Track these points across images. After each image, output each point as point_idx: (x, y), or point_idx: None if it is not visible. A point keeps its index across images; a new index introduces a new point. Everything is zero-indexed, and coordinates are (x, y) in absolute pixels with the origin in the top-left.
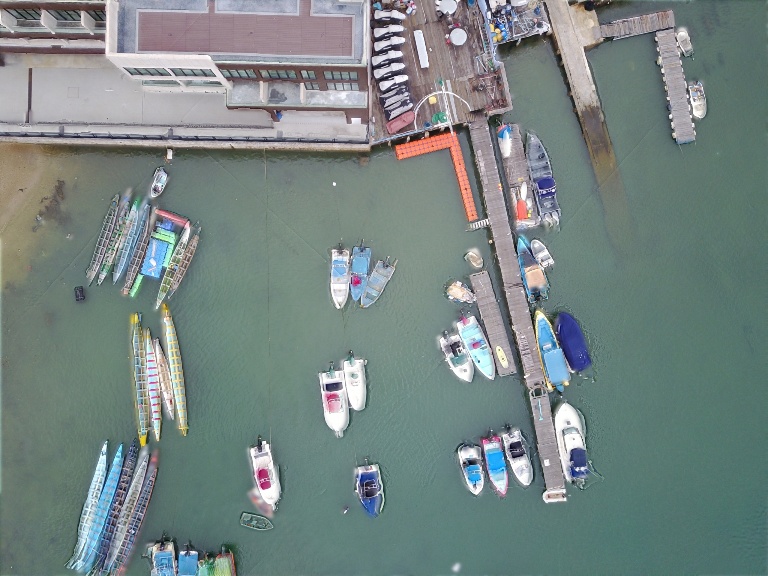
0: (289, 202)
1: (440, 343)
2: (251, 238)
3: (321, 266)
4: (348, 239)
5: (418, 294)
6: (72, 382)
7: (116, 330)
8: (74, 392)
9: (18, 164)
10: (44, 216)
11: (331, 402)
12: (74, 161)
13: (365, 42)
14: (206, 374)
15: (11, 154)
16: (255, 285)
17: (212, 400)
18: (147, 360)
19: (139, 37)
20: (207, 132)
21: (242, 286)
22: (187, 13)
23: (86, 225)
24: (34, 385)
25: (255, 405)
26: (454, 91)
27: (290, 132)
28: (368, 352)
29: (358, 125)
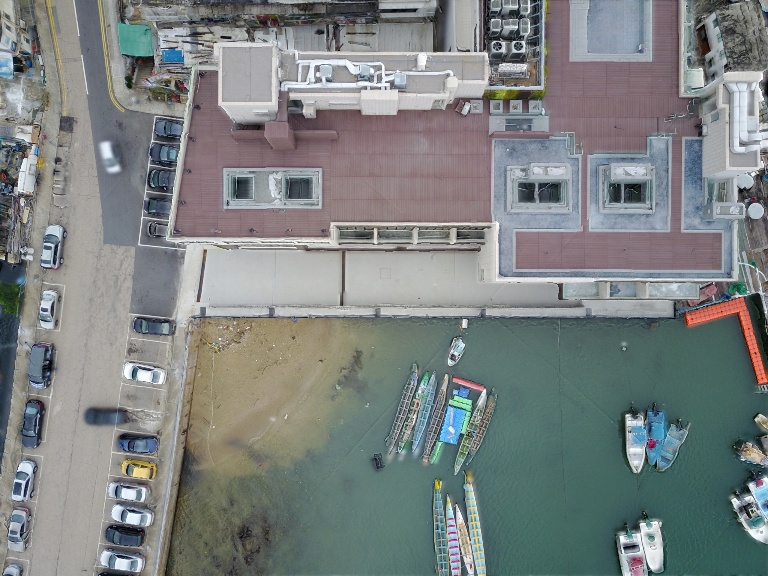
0: (579, 367)
1: (732, 504)
2: (543, 403)
3: (607, 426)
4: (639, 403)
5: (708, 455)
6: (371, 547)
7: (415, 496)
8: (373, 557)
9: (318, 336)
10: (343, 385)
11: (636, 569)
12: (371, 331)
13: (736, 258)
14: (502, 537)
15: (311, 326)
16: (549, 449)
17: (508, 562)
18: (447, 526)
19: (517, 256)
20: (519, 311)
21: (535, 450)
22: (562, 232)
23: (382, 393)
24: (334, 550)
25: (553, 568)
26: (750, 262)
27: (599, 309)
28: (661, 513)
29: (665, 301)
